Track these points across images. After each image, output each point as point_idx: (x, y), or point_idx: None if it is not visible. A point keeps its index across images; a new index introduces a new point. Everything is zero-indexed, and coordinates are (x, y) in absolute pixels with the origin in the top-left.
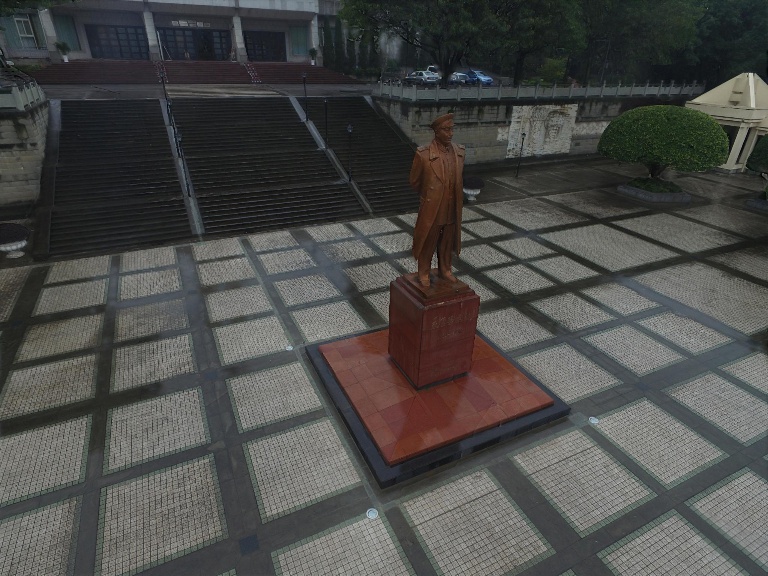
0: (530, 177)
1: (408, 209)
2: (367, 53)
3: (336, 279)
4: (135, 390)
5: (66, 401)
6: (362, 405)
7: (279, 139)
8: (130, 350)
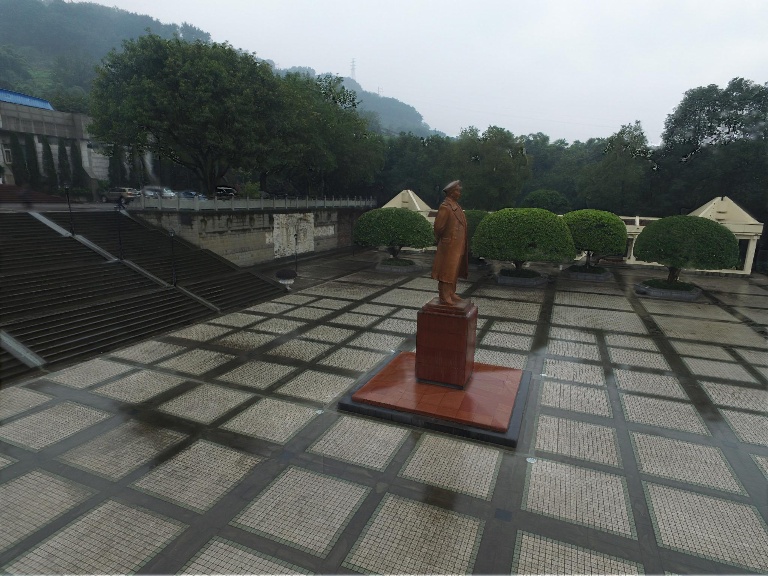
0: (307, 270)
1: (247, 303)
2: (70, 173)
3: (272, 360)
4: (227, 498)
5: (158, 546)
6: (443, 412)
7: (53, 255)
8: (153, 477)
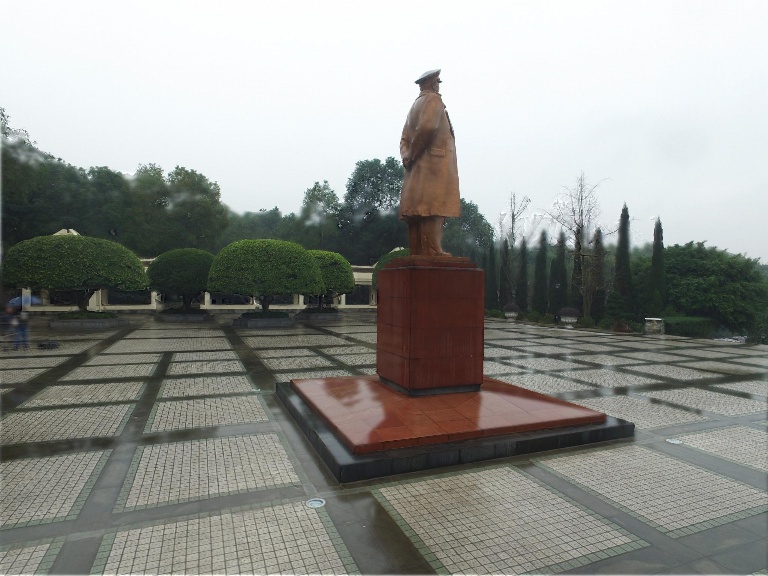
0: None
1: None
2: None
3: (5, 455)
4: None
5: None
6: (518, 419)
7: None
8: None
